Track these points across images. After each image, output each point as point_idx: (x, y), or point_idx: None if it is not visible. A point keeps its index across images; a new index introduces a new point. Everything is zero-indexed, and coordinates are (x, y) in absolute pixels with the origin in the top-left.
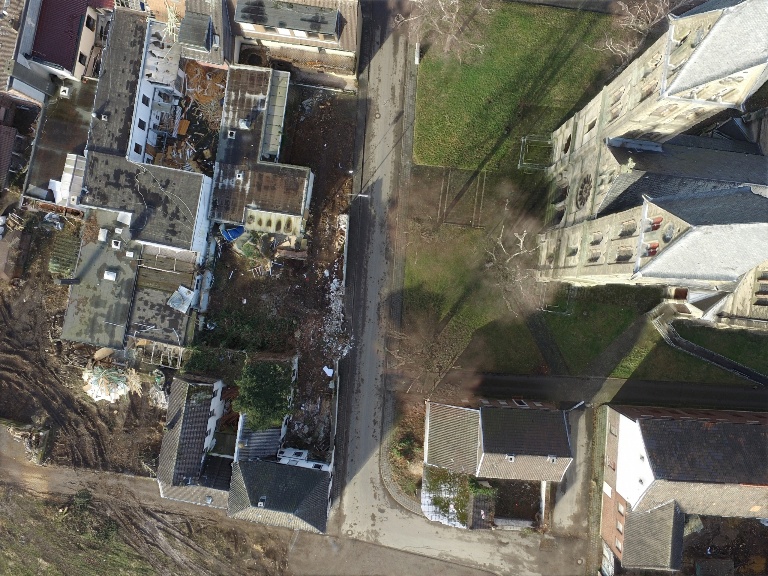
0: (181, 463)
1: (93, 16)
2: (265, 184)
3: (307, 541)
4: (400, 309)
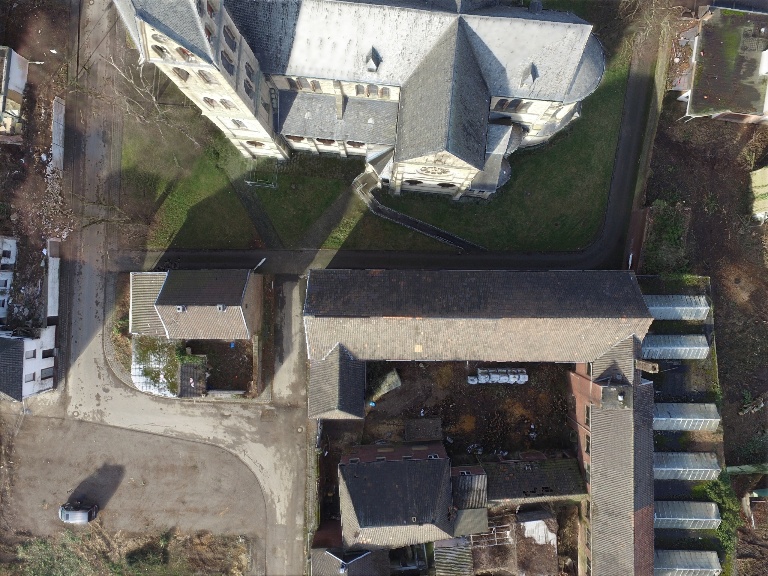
0: None
1: None
2: None
3: (33, 424)
4: (118, 190)
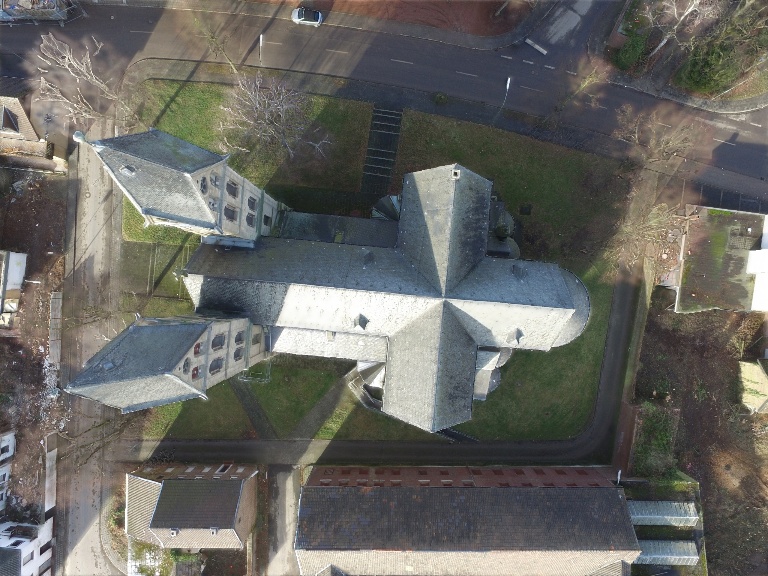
0: None
1: None
2: None
3: None
4: None
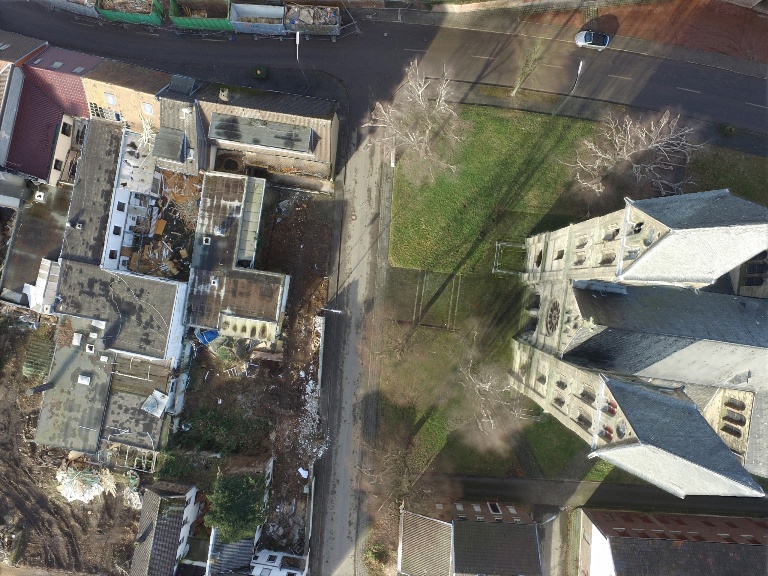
0: None
1: (69, 122)
2: (240, 290)
3: None
4: (375, 410)
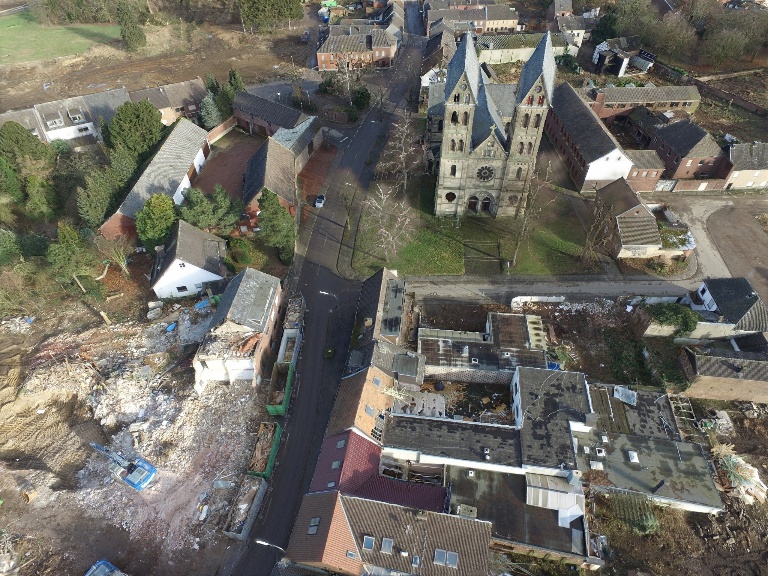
0: None
1: None
2: (508, 338)
3: None
4: (565, 276)
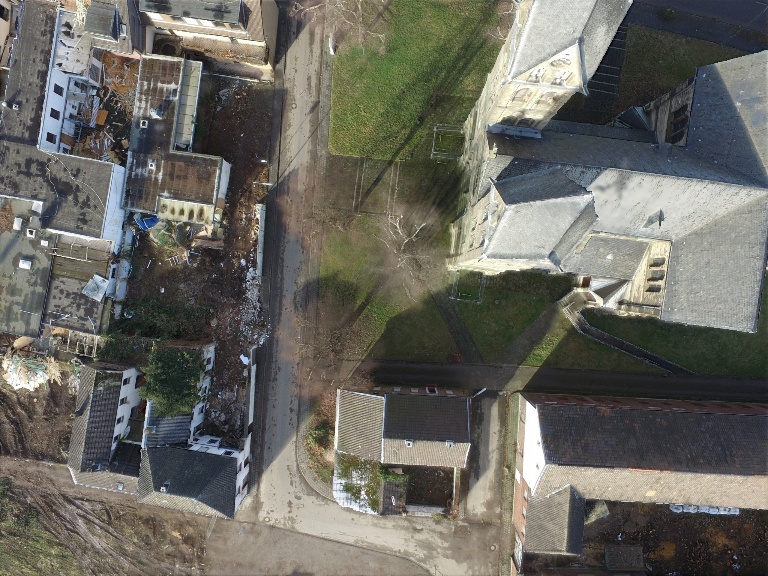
0: (90, 449)
1: (6, 6)
2: (178, 173)
3: (225, 528)
4: (316, 298)
